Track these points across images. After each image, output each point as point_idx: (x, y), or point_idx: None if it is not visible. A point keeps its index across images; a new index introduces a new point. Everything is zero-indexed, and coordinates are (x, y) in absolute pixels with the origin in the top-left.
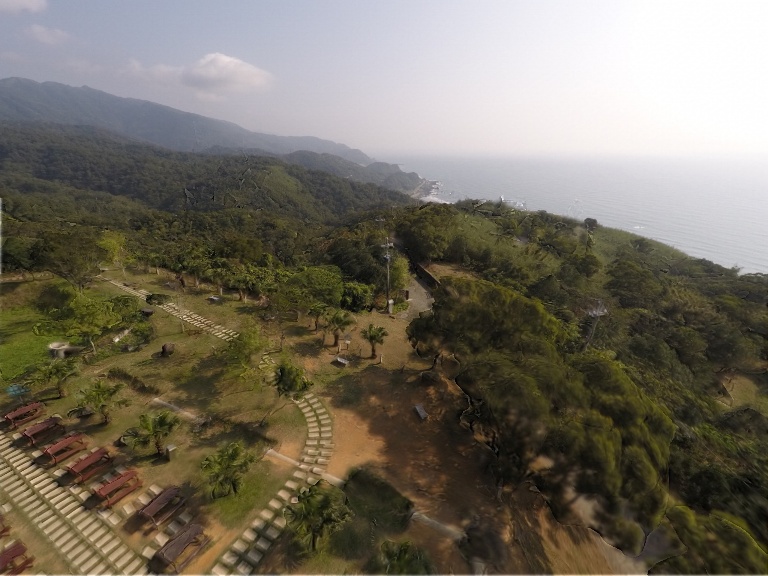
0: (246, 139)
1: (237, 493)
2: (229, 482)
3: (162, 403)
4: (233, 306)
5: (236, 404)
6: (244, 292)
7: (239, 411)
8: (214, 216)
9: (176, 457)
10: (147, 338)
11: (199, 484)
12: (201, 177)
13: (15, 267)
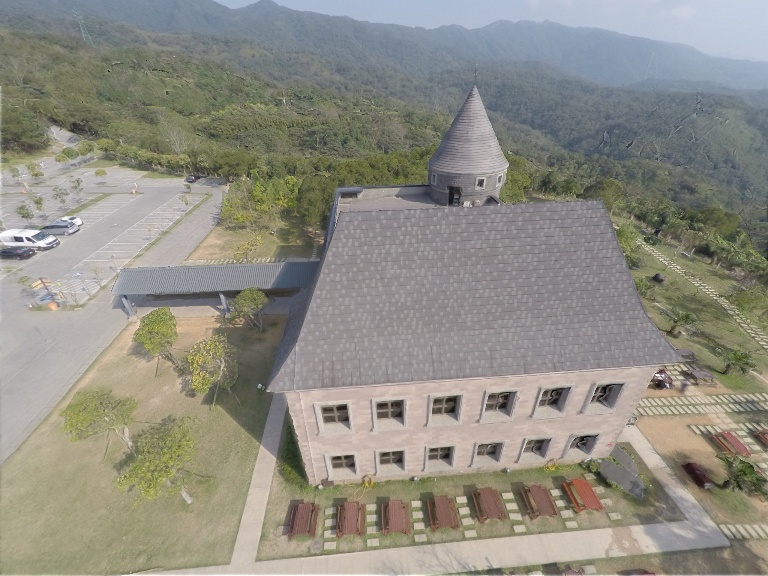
0: (713, 74)
1: (744, 374)
2: (738, 366)
3: (661, 307)
4: (704, 267)
5: (718, 333)
6: (720, 259)
7: (721, 338)
8: (626, 166)
9: (681, 338)
10: (637, 264)
11: (699, 359)
12: (627, 119)
13: (552, 190)
